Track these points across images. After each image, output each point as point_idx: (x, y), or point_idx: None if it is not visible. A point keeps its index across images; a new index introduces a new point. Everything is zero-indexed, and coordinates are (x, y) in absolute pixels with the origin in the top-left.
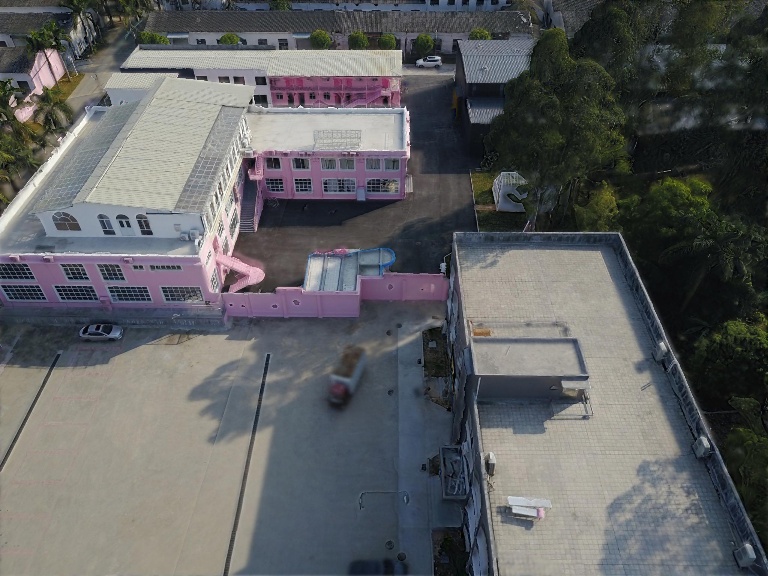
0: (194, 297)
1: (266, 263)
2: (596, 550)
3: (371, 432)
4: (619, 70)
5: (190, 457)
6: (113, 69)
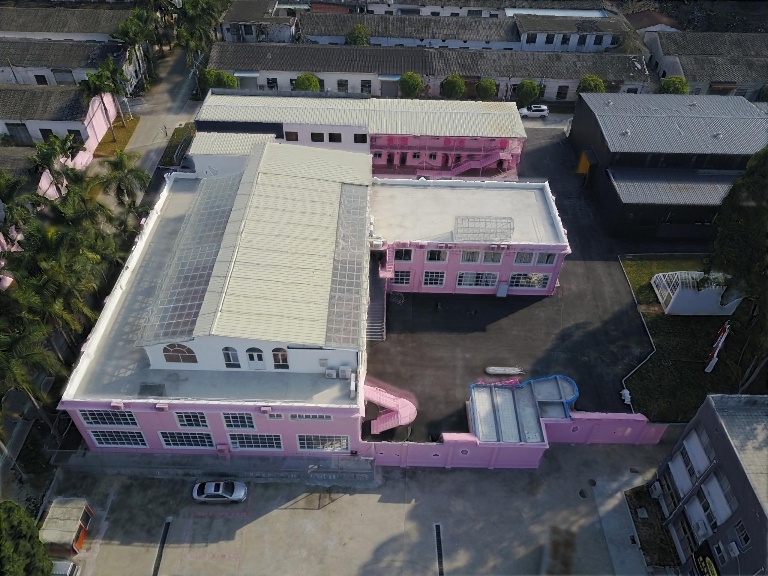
0: (336, 445)
1: (408, 387)
2: None
3: None
4: None
5: None
6: (172, 111)
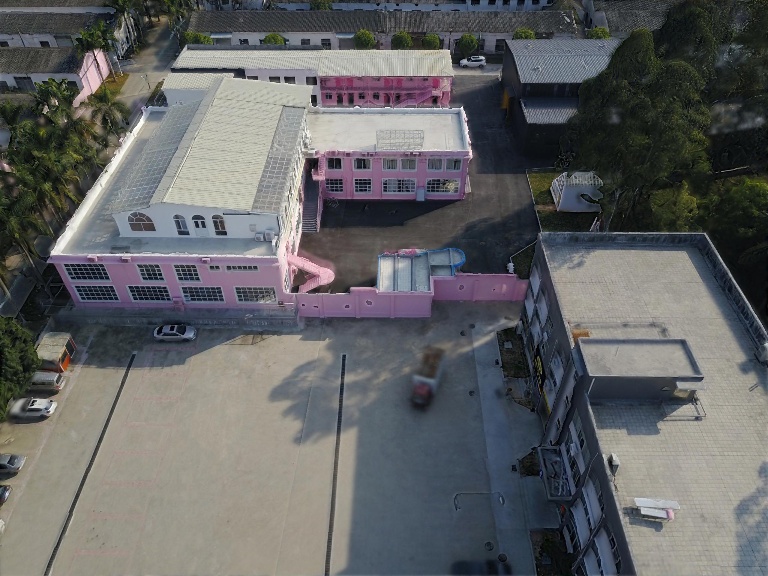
0: (267, 297)
1: (332, 263)
2: (730, 552)
3: (457, 433)
4: (699, 70)
5: (278, 458)
6: (157, 69)
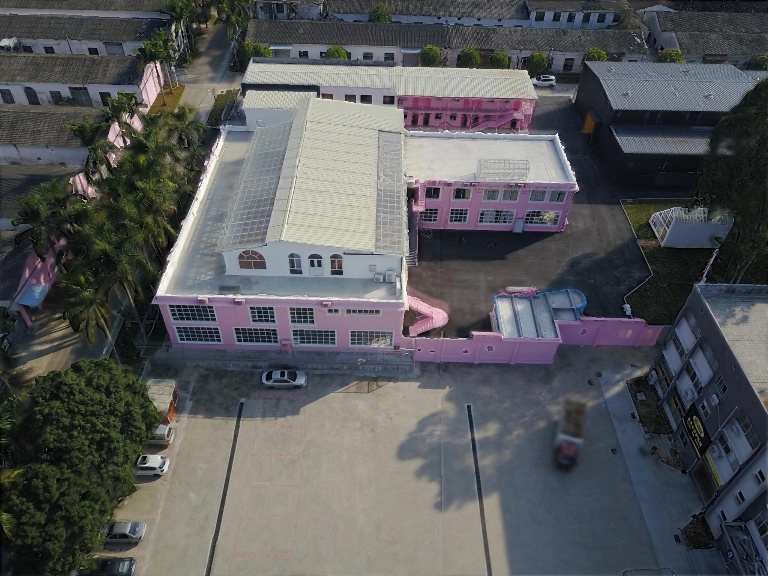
0: (381, 341)
1: (439, 301)
2: None
3: (607, 497)
4: None
5: (421, 525)
6: (213, 80)
